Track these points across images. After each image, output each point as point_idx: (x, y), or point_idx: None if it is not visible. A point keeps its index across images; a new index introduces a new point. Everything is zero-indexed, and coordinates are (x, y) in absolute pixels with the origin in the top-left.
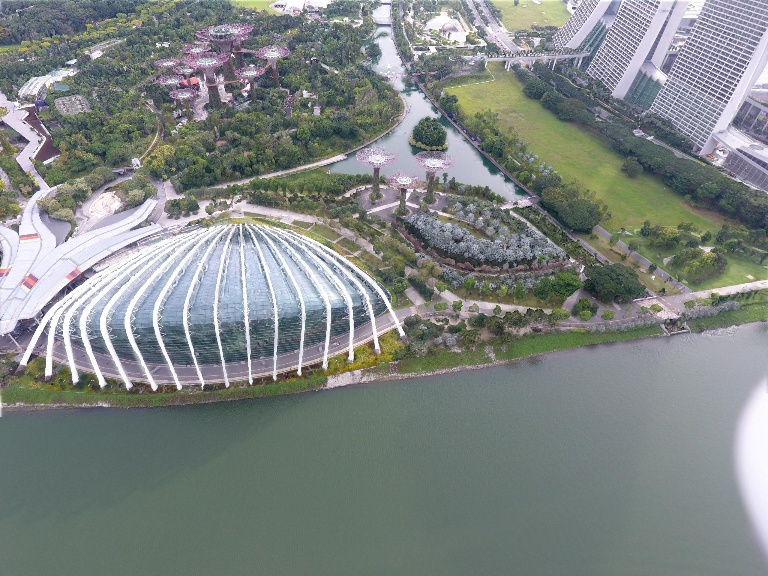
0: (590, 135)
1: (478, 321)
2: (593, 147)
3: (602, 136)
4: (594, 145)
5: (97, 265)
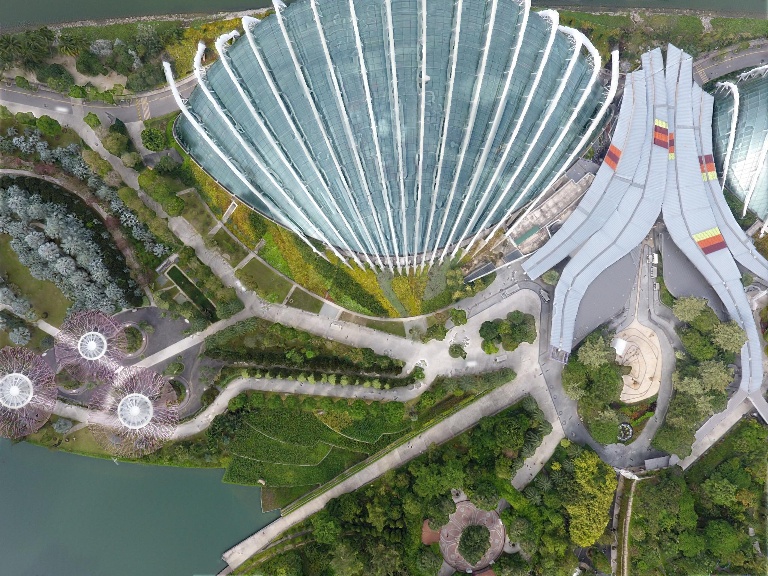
0: None
1: (57, 68)
2: None
3: None
4: None
5: (590, 182)
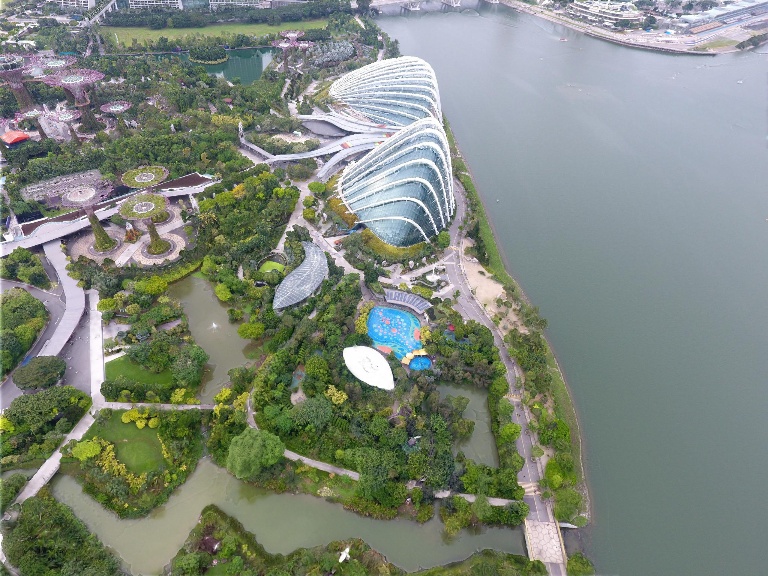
0: (226, 25)
1: None
2: None
3: (230, 23)
4: (239, 26)
5: None
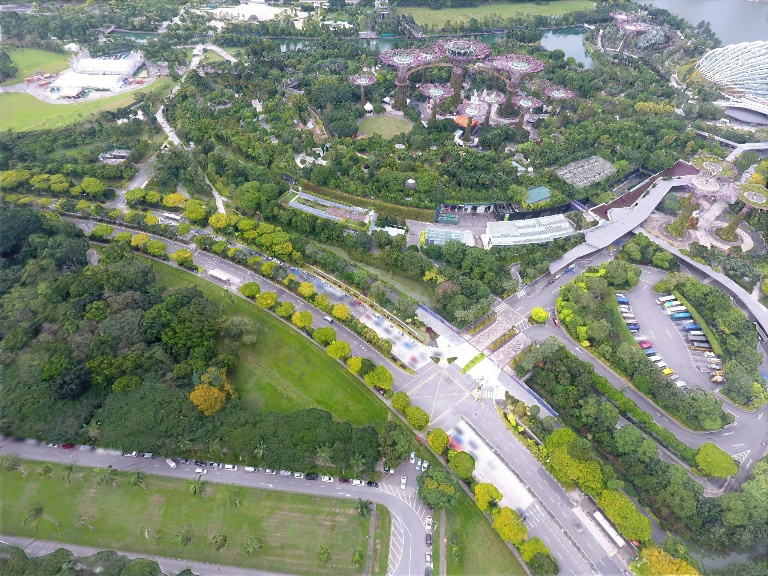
0: (496, 4)
1: None
2: (513, 6)
3: (497, 2)
4: (510, 5)
5: None
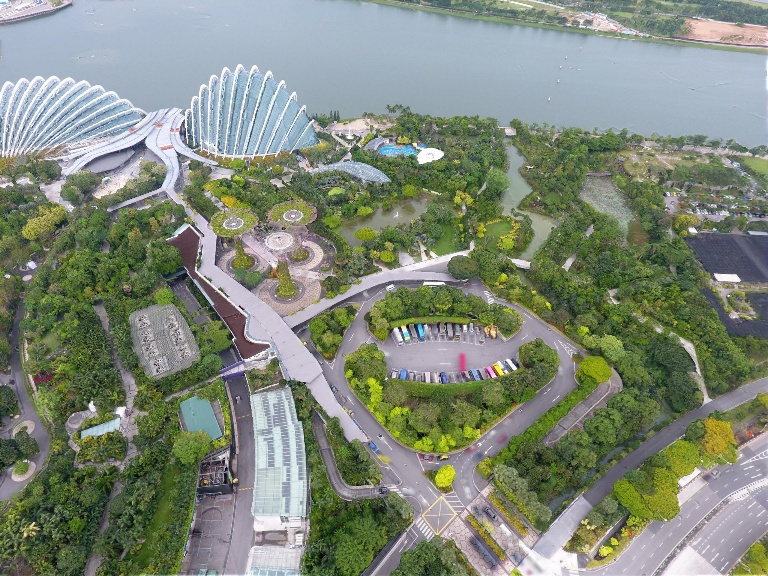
0: None
1: None
2: None
3: None
4: None
5: None
